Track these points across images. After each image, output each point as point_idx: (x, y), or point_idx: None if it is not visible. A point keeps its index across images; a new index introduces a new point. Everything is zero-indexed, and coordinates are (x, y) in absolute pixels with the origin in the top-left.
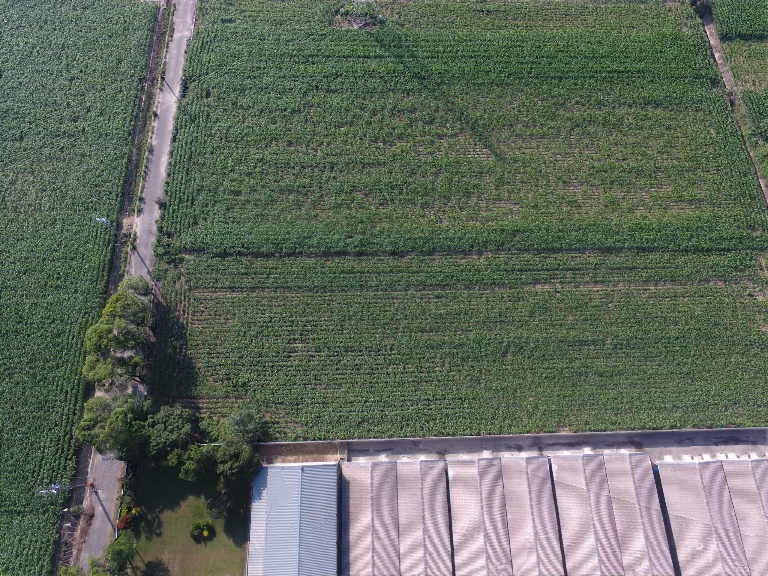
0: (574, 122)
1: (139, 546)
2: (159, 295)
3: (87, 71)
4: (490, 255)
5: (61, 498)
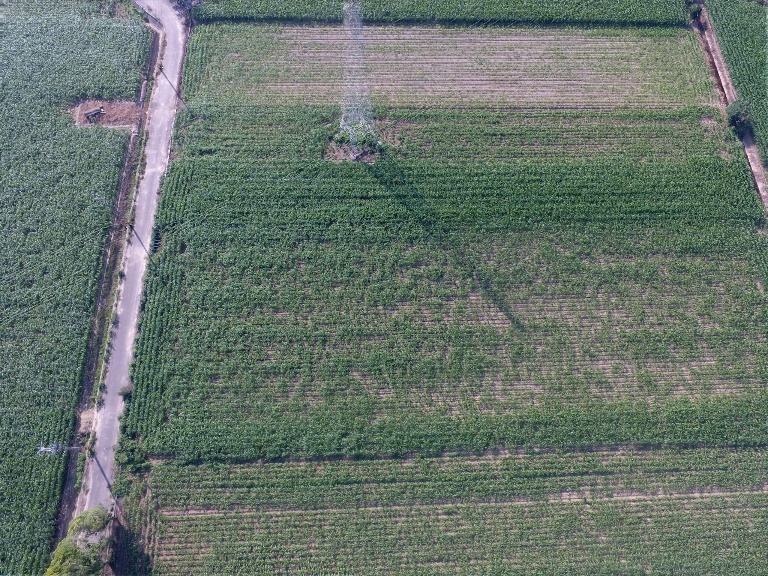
0: (602, 277)
1: None
2: (120, 516)
3: (44, 221)
4: (508, 455)
5: None
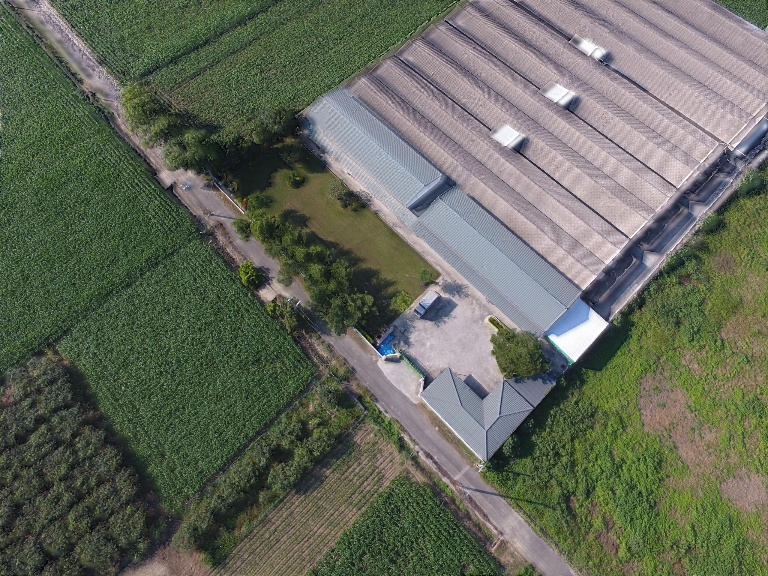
0: None
1: None
2: None
3: None
4: None
5: (192, 230)
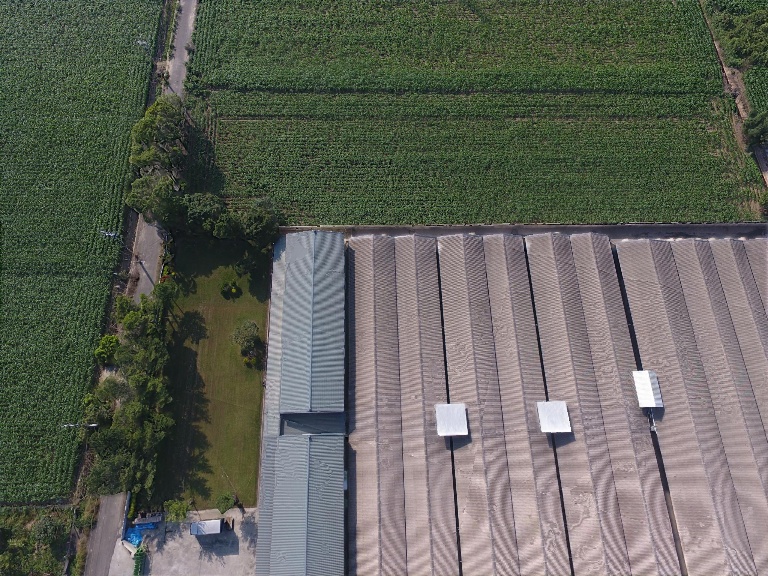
0: None
1: (178, 300)
2: (190, 120)
3: None
4: (476, 94)
5: (111, 265)
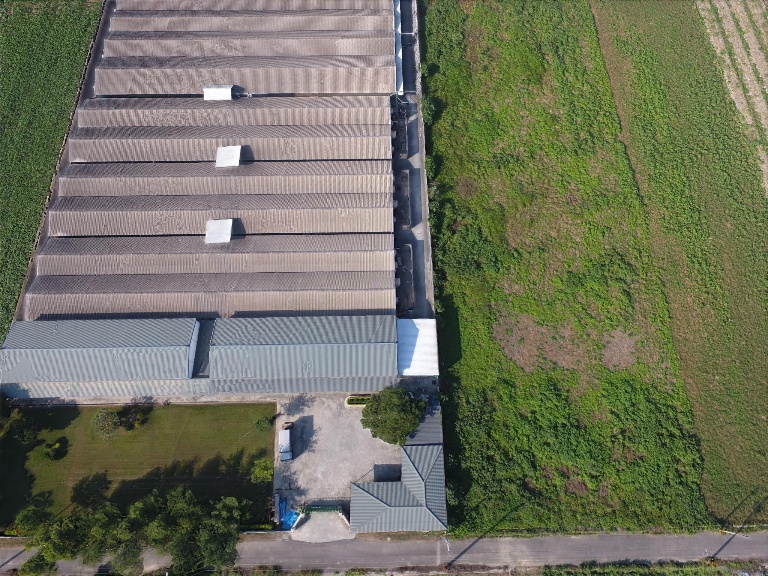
0: None
1: (54, 513)
2: None
3: None
4: None
5: None
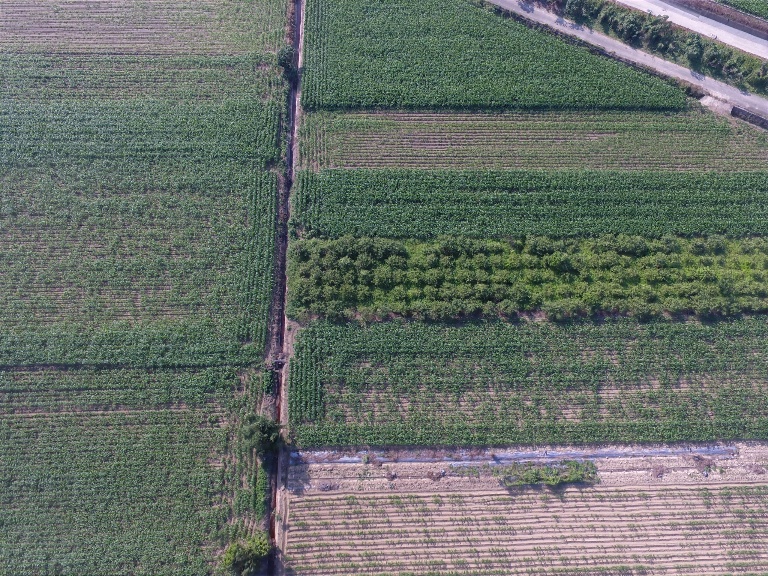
0: (87, 210)
1: None
2: None
3: None
4: None
5: None
